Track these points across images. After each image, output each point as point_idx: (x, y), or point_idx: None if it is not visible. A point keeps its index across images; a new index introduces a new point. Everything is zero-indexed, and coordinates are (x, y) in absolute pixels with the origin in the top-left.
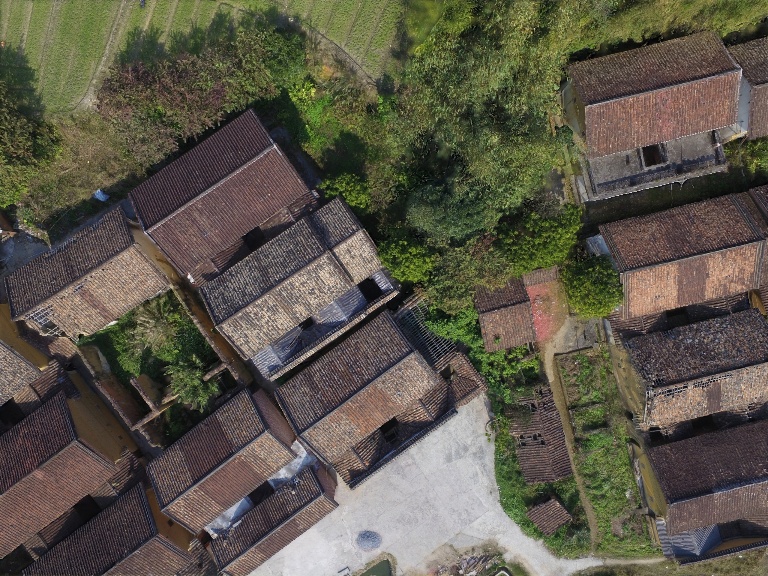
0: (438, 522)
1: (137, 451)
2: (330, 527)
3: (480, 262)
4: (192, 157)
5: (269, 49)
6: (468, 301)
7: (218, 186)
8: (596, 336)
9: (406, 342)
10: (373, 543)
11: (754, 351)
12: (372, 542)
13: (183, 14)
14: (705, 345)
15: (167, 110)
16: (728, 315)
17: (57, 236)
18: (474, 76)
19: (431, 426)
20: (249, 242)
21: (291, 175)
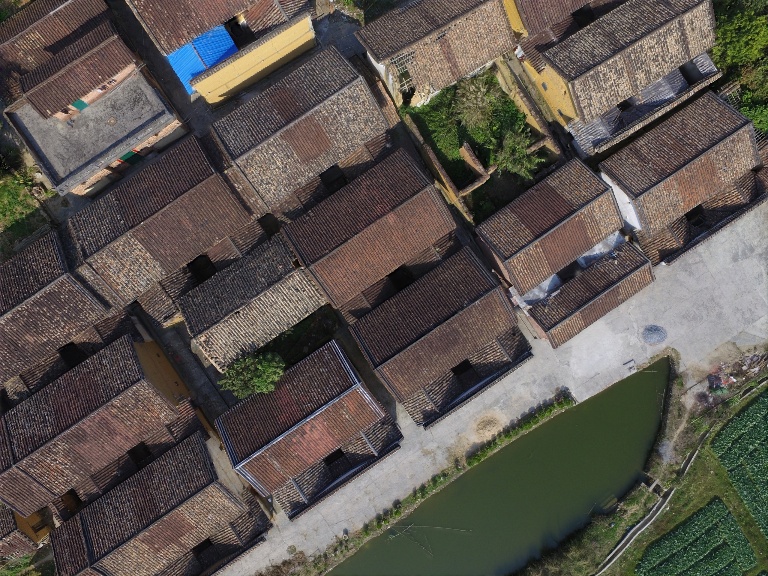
0: (722, 320)
1: None
2: (617, 320)
3: None
4: None
5: None
6: None
7: None
8: None
9: (739, 115)
10: (660, 336)
11: None
12: (659, 335)
13: None
14: None
15: None
16: None
17: (372, 17)
18: None
19: (748, 206)
20: (578, 20)
21: None
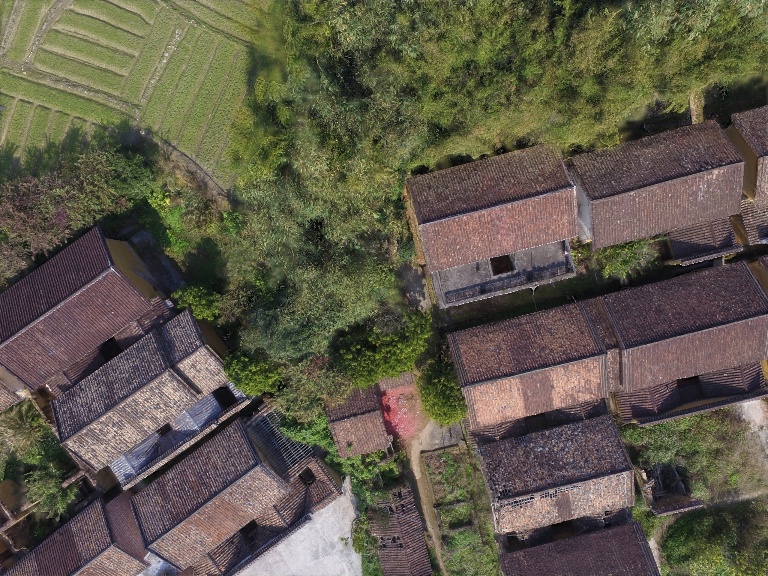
0: None
1: (8, 550)
2: None
3: (318, 380)
4: (39, 275)
5: (112, 168)
6: (318, 410)
7: (58, 308)
8: (462, 433)
9: (253, 454)
10: None
11: (601, 462)
12: None
13: (37, 129)
14: (555, 454)
15: (10, 233)
16: (581, 422)
17: None
18: (293, 207)
19: (284, 533)
20: (105, 351)
21: (133, 293)
